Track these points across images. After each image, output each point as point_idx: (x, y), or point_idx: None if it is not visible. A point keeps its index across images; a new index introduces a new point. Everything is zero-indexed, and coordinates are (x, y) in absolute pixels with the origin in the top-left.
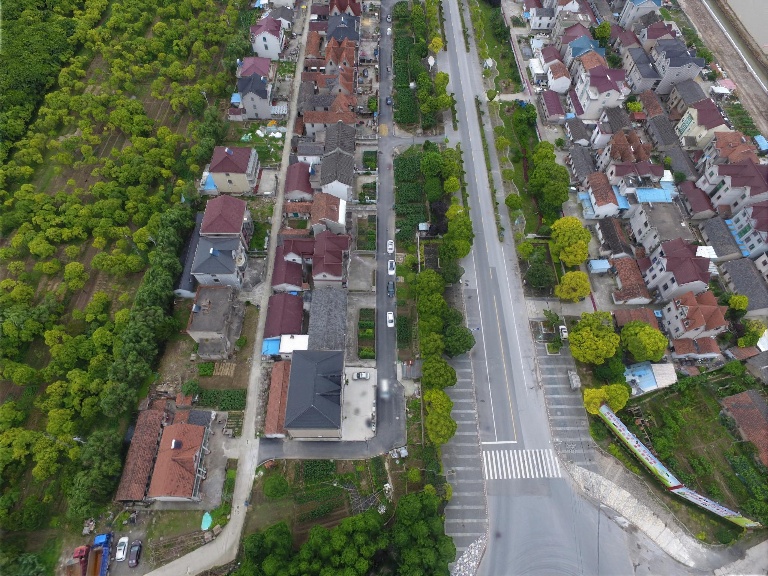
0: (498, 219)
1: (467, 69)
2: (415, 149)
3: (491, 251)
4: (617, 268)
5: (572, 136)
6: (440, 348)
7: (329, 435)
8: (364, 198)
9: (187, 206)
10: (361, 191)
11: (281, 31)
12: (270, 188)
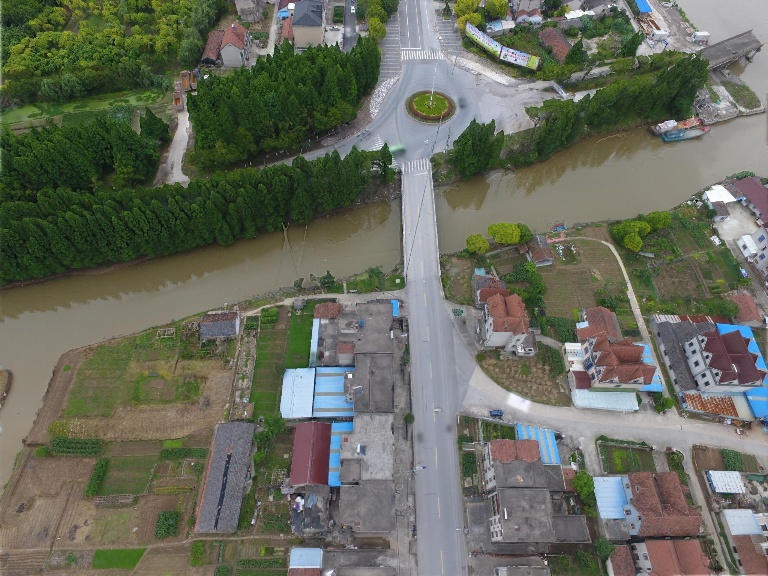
0: None
1: None
2: None
3: None
4: None
5: None
6: (379, 4)
7: (316, 45)
8: None
9: None
10: None
11: None
12: None
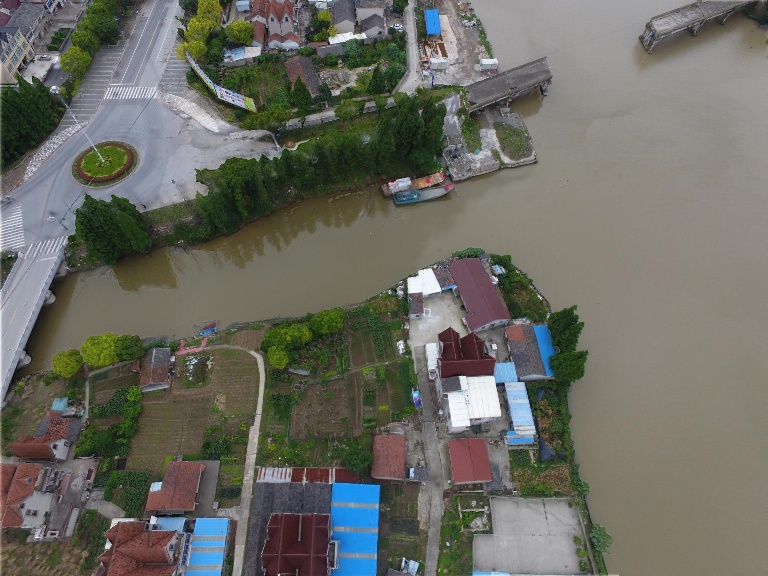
0: None
1: None
2: None
3: None
4: (253, 4)
5: None
6: (89, 28)
7: (5, 80)
8: None
9: None
10: None
11: None
12: None
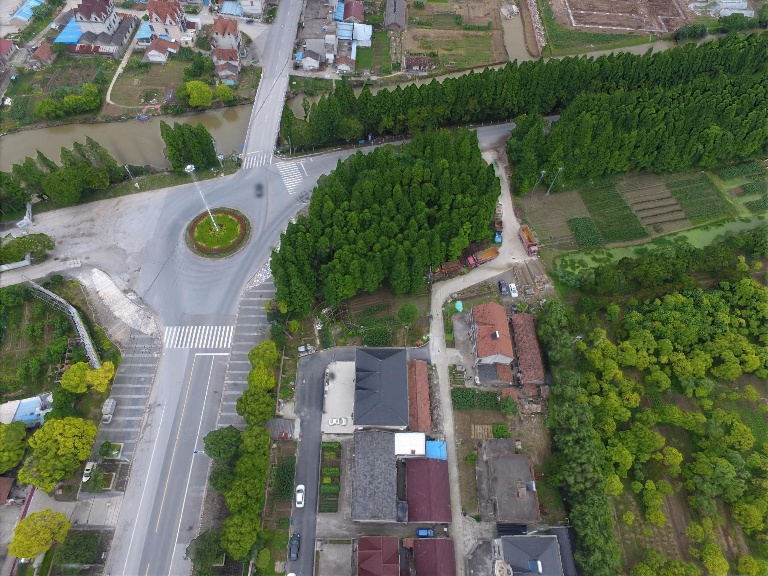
0: None
1: None
2: None
3: None
4: None
5: None
6: (247, 430)
7: None
8: None
9: None
10: None
11: None
12: None
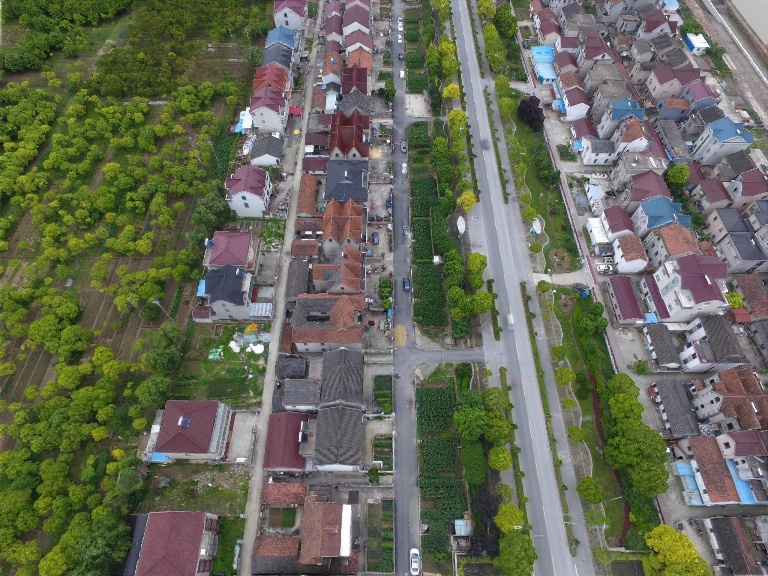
0: (568, 517)
1: (507, 232)
2: (444, 371)
3: (560, 575)
4: None
5: (656, 355)
6: None
7: None
8: (376, 476)
9: (123, 504)
10: (371, 450)
11: (266, 184)
12: (245, 448)
